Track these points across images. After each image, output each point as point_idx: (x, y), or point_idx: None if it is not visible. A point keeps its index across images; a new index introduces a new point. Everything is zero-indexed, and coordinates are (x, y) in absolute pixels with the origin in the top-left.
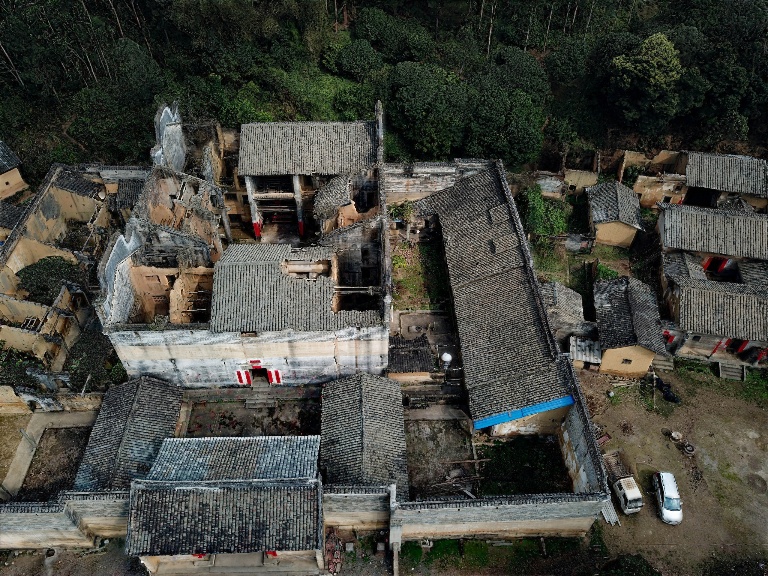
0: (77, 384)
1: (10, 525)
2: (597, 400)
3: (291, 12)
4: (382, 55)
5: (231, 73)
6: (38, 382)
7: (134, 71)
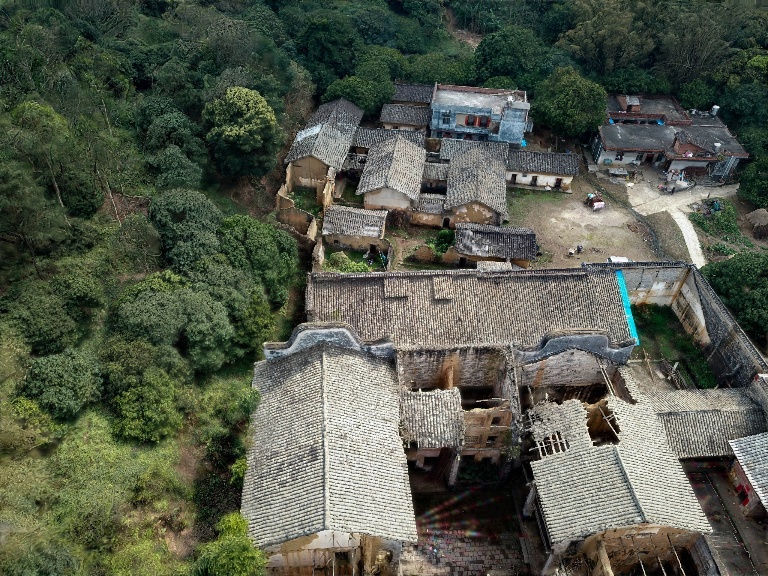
0: None
1: None
2: None
3: None
4: None
5: None
6: None
7: None
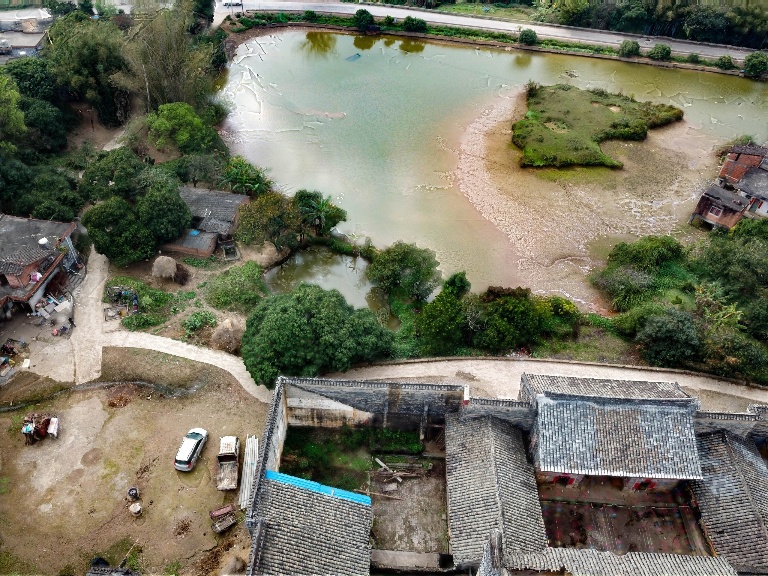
0: None
1: None
2: (194, 573)
3: None
4: None
5: None
6: None
7: None
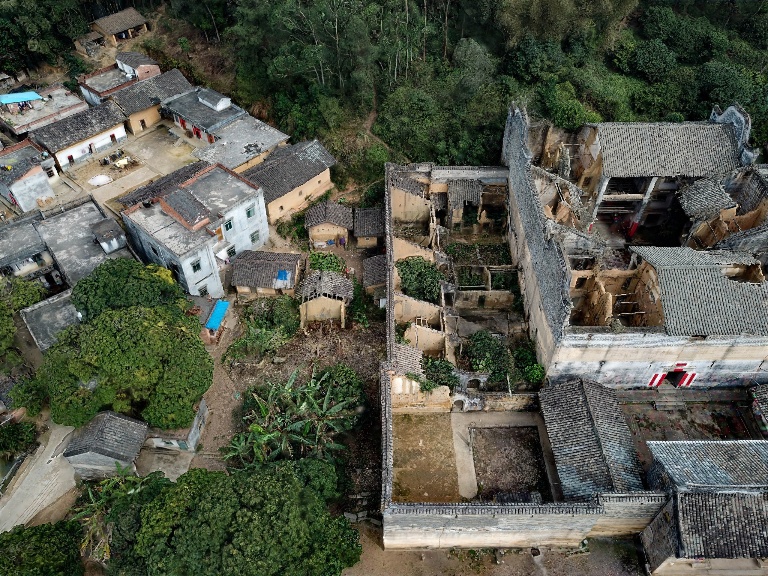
0: (490, 384)
1: (531, 525)
2: None
3: (605, 11)
4: (675, 54)
5: (542, 73)
6: (460, 382)
7: (478, 71)
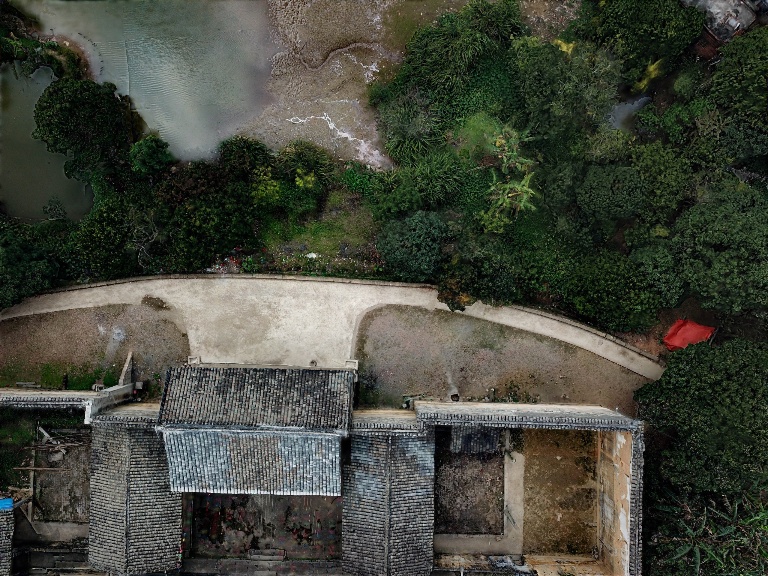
0: None
1: None
2: None
3: None
4: None
5: None
6: None
7: None
